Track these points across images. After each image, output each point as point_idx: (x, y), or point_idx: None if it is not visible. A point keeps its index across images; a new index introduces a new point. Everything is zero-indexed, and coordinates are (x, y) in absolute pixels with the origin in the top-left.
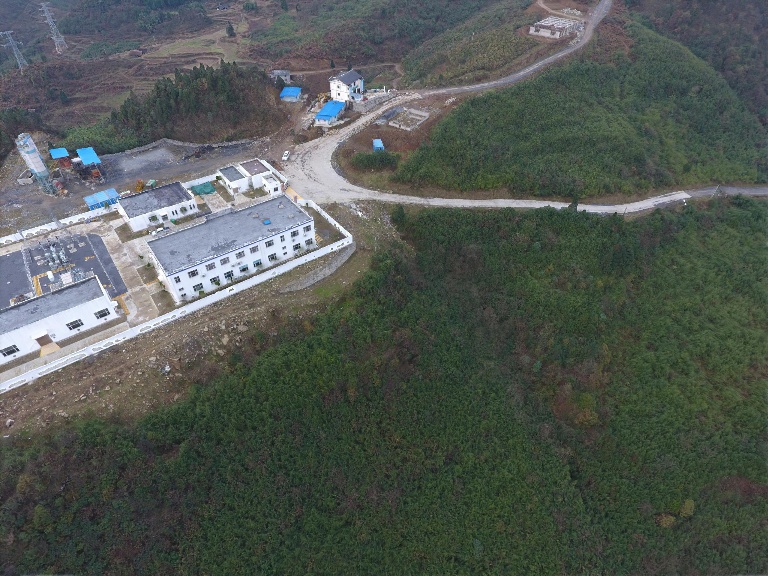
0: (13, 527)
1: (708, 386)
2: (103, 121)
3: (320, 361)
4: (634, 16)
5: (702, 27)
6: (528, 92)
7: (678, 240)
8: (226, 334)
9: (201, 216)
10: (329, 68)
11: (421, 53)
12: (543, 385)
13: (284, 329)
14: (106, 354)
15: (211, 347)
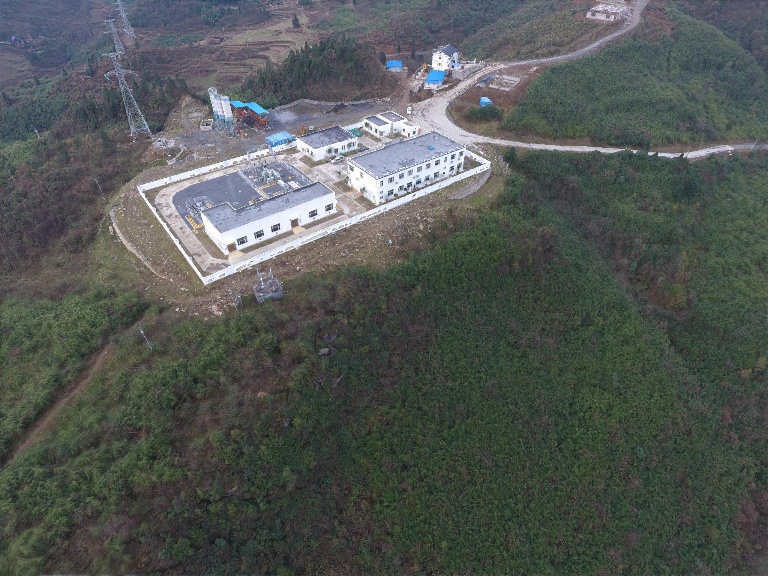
0: (346, 315)
1: (767, 282)
2: (237, 88)
3: (493, 242)
4: (671, 4)
5: (730, 14)
6: (596, 63)
7: (730, 179)
8: (421, 223)
9: (362, 151)
10: (395, 53)
11: (479, 39)
12: (638, 281)
13: (460, 222)
14: (342, 233)
15: (413, 231)
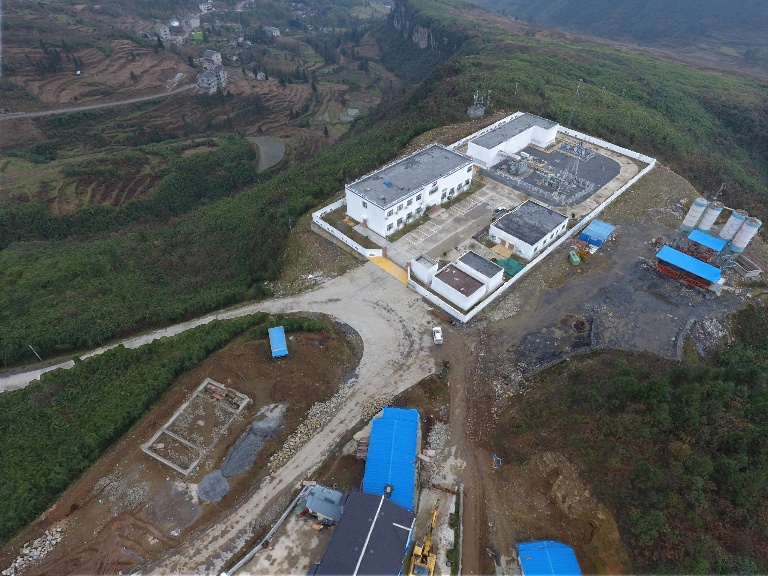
0: None
1: None
2: None
3: None
4: None
5: None
6: None
7: None
8: None
9: None
10: None
11: None
12: None
13: None
14: None
15: None
